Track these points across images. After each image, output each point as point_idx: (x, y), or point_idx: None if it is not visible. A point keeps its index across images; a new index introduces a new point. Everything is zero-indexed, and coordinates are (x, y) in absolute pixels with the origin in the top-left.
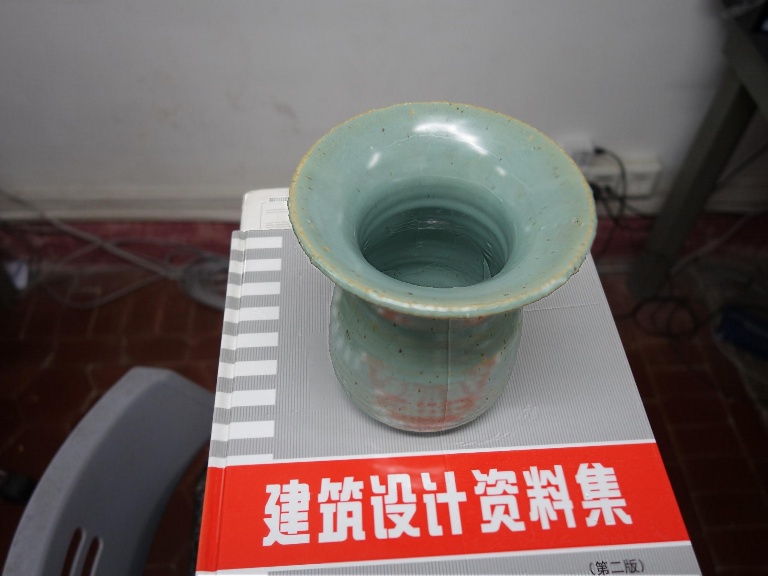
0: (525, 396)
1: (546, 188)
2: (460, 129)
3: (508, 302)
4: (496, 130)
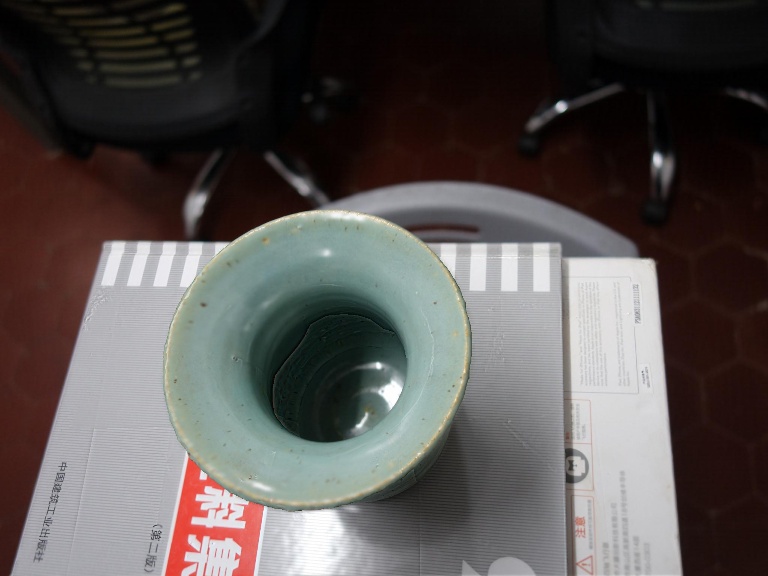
0: (317, 514)
1: (322, 469)
2: (432, 390)
3: (165, 379)
4: (418, 429)
